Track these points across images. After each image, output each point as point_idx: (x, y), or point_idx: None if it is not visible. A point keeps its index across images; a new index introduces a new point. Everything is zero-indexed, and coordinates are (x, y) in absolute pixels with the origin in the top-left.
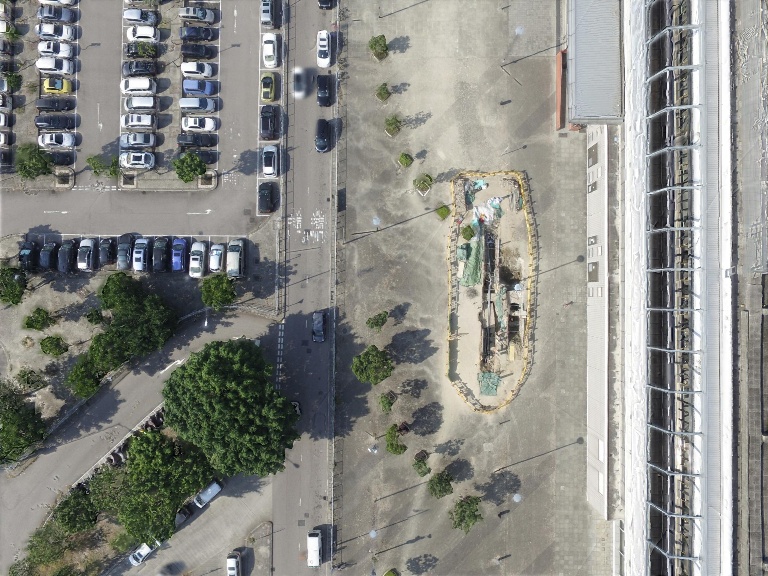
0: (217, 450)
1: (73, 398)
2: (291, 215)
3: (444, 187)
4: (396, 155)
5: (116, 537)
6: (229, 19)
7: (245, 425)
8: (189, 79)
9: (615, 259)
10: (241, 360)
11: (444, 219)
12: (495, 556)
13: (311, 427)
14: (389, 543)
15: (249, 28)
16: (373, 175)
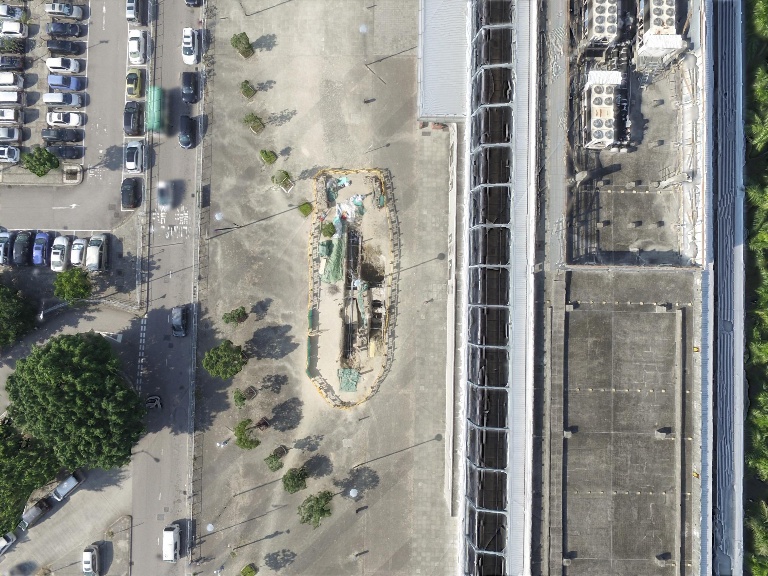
0: (58, 443)
1: None
2: (155, 210)
3: (308, 184)
4: None
5: None
6: (98, 16)
7: (85, 418)
8: None
9: (463, 256)
10: (82, 353)
11: (307, 216)
12: (353, 552)
13: (172, 421)
14: (248, 538)
15: (117, 25)
16: (238, 171)
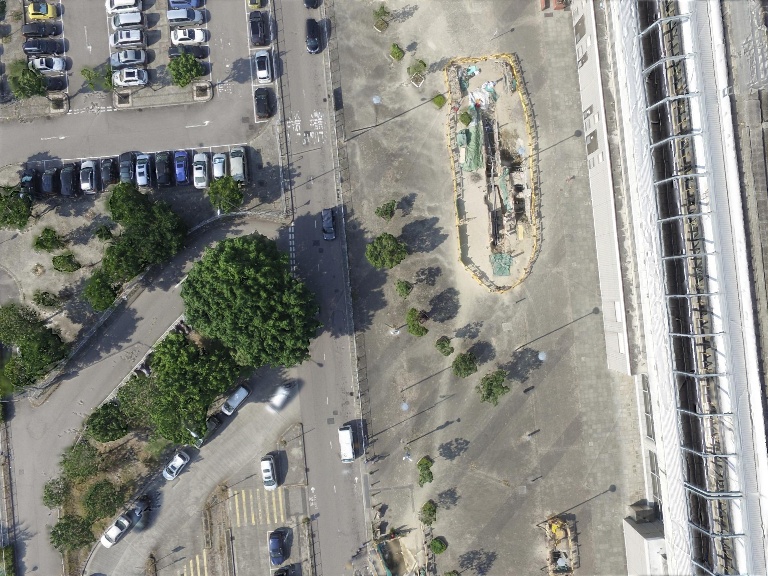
0: (242, 342)
1: (90, 321)
2: (289, 118)
3: (438, 76)
4: (387, 50)
5: (147, 455)
6: None
7: (267, 313)
8: None
9: (613, 121)
10: (256, 250)
11: (441, 108)
12: (524, 433)
13: (331, 325)
14: (419, 431)
15: None
16: (367, 71)
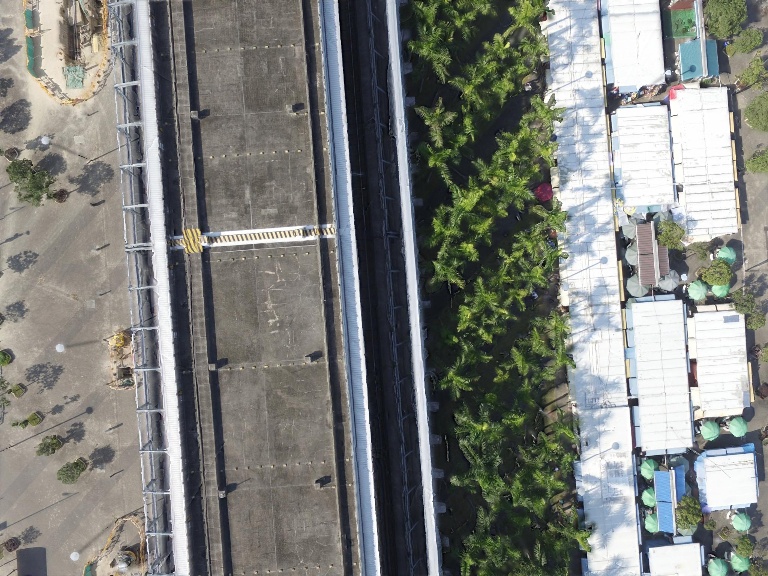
0: None
1: None
2: None
3: None
4: None
5: None
6: None
7: None
8: None
9: None
10: None
11: None
12: (94, 247)
13: None
14: None
15: None
16: None
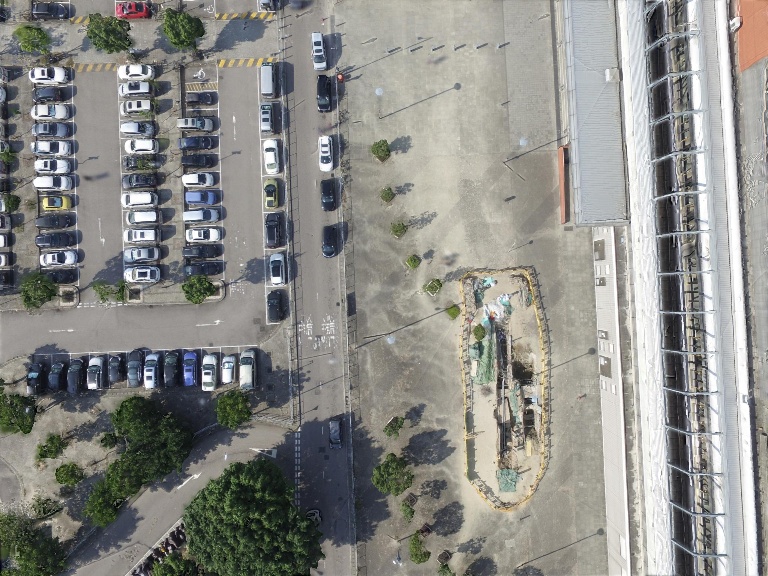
0: None
1: (90, 519)
2: (301, 322)
3: (453, 286)
4: (404, 256)
5: None
6: (228, 126)
7: (270, 552)
8: (191, 191)
9: (628, 359)
10: (262, 487)
11: (455, 318)
12: None
13: (333, 534)
14: None
15: (249, 134)
16: (382, 277)
